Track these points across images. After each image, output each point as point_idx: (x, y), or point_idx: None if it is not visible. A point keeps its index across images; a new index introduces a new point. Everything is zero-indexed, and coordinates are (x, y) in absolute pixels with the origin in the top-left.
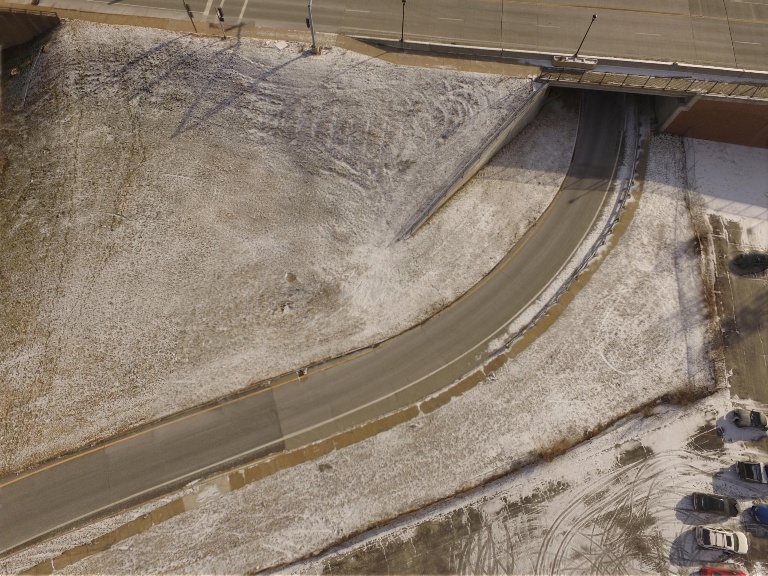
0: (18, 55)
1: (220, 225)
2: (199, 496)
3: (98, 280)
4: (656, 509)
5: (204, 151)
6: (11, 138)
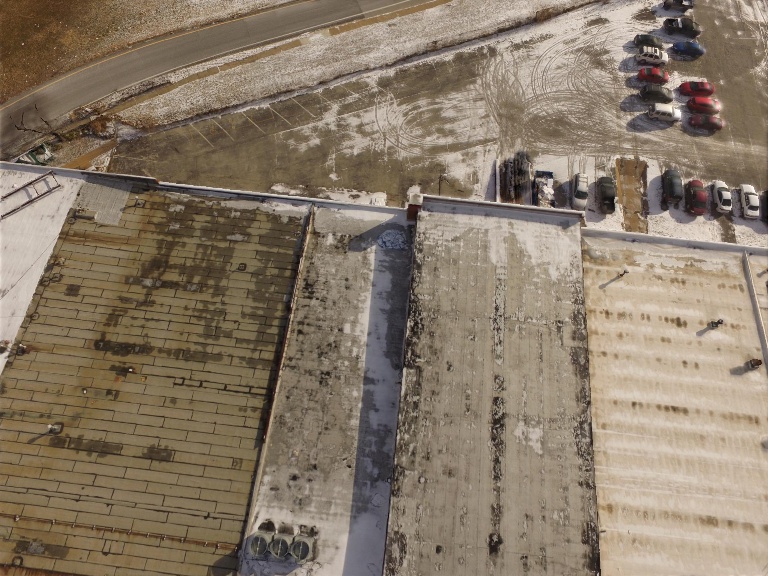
0: None
1: None
2: (310, 38)
3: None
4: (610, 46)
5: None
6: None
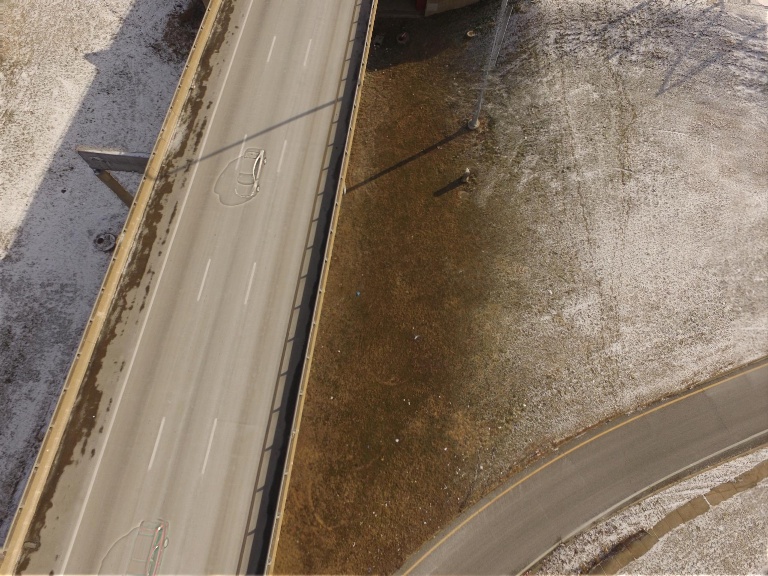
0: (464, 18)
1: (725, 180)
2: None
3: (627, 232)
4: None
5: (692, 108)
6: (489, 97)
